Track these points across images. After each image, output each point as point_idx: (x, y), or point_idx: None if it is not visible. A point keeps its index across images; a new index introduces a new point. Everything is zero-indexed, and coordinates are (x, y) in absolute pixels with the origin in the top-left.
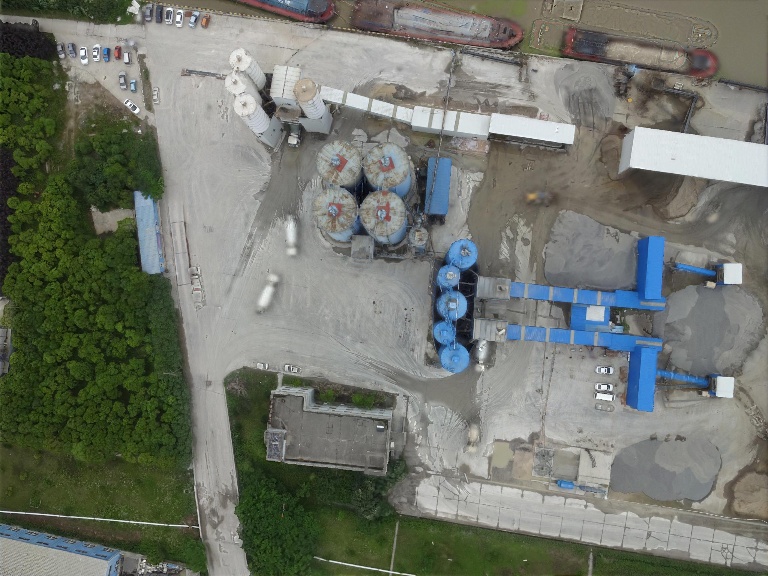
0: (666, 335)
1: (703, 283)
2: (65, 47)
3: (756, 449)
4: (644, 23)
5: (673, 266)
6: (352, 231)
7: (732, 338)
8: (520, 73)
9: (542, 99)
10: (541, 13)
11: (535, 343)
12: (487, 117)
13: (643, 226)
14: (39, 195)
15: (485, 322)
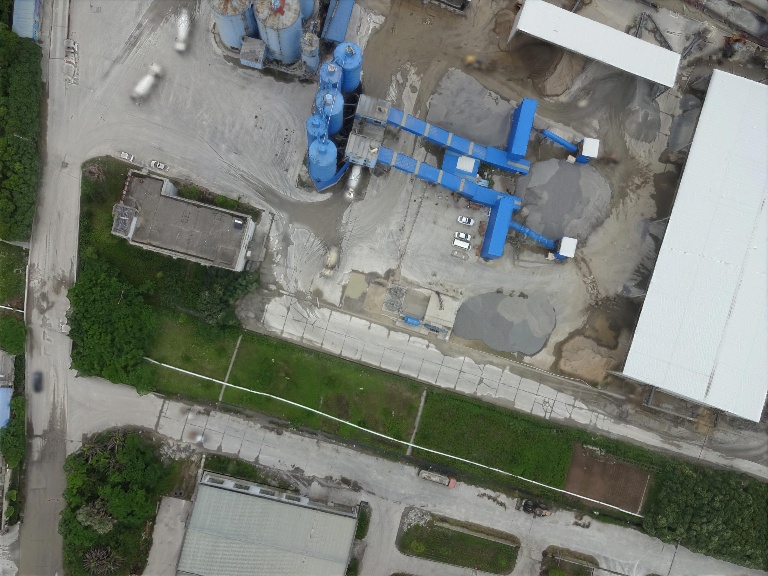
0: (526, 198)
1: (565, 158)
2: None
3: (587, 315)
4: None
5: (541, 132)
6: (244, 28)
7: (582, 208)
8: None
9: None
10: None
11: (406, 185)
12: None
13: (522, 97)
14: None
15: (360, 138)
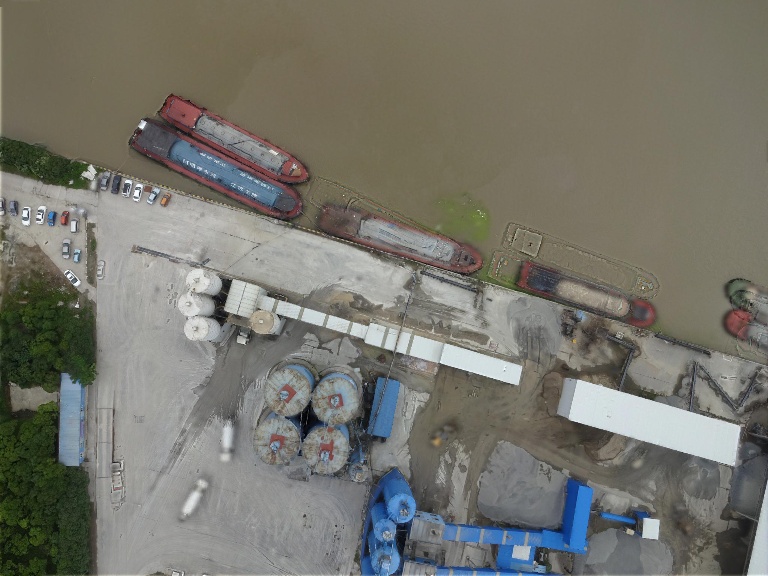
0: None
1: (623, 527)
2: (6, 203)
3: None
4: (595, 268)
5: (598, 514)
6: None
7: None
8: (476, 299)
9: (494, 328)
10: (502, 242)
11: None
12: (440, 344)
13: (574, 465)
14: None
15: (415, 566)
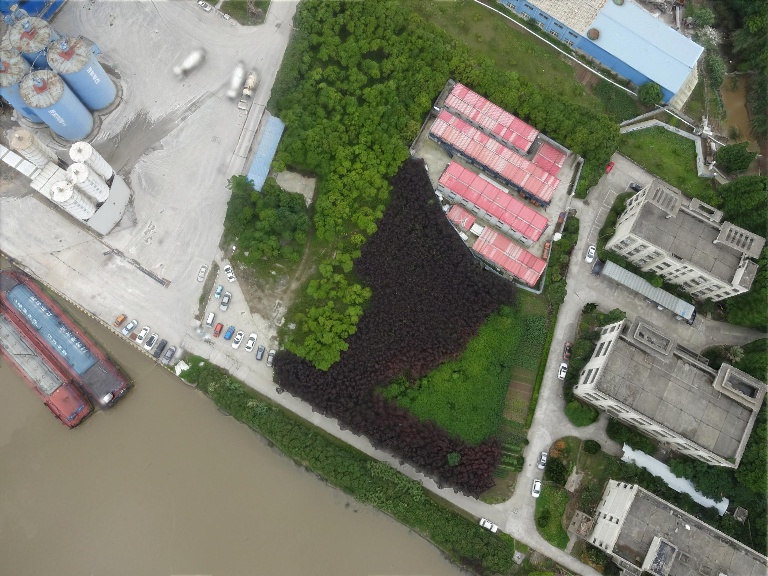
0: None
1: None
2: None
3: None
4: None
5: None
6: None
7: None
8: None
9: None
10: None
11: None
12: None
13: None
14: (352, 234)
15: None
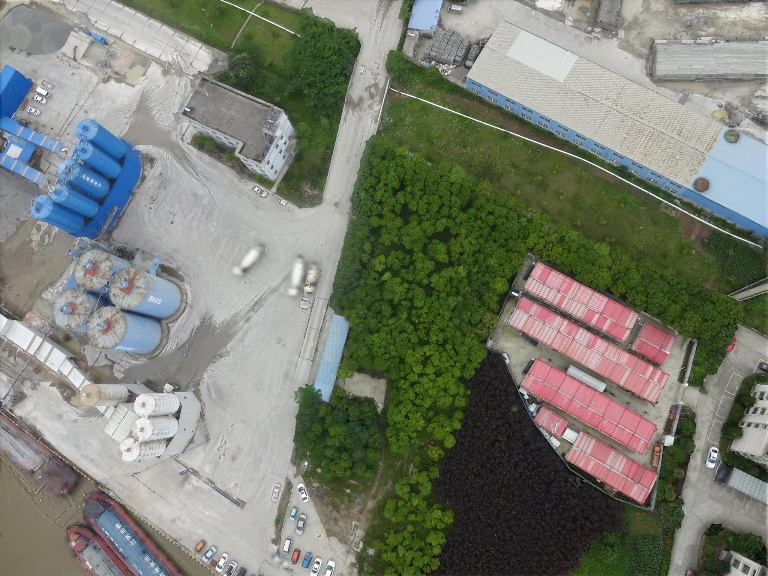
0: None
1: None
2: None
3: None
4: None
5: None
6: None
7: None
8: None
9: None
10: None
11: None
12: (8, 337)
13: None
14: (429, 443)
15: None
